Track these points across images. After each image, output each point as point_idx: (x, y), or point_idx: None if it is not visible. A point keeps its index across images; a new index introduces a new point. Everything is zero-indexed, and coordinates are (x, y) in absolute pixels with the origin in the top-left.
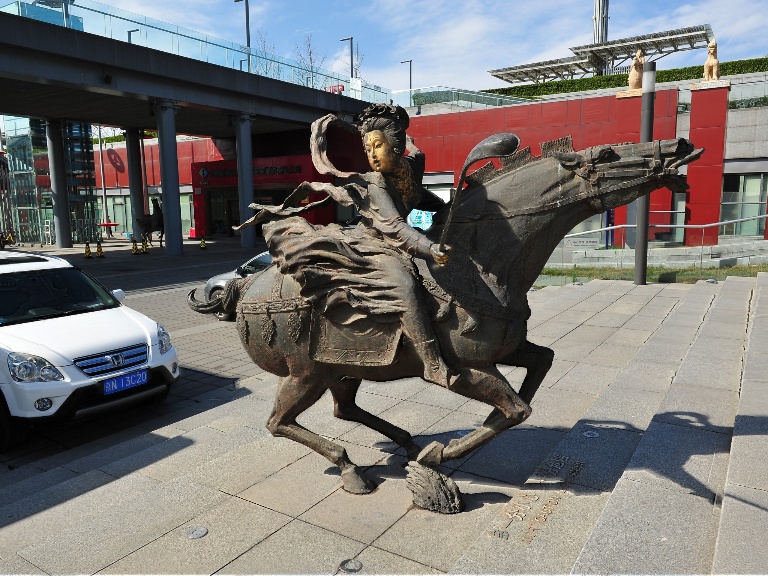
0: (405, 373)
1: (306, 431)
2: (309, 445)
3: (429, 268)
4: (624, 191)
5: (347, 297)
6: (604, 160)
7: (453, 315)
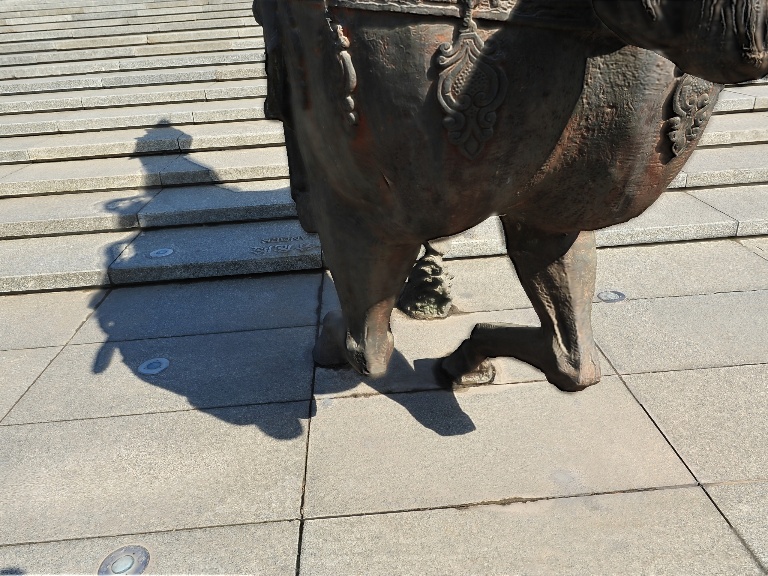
0: None
1: None
2: None
3: None
4: None
5: None
6: None
7: None
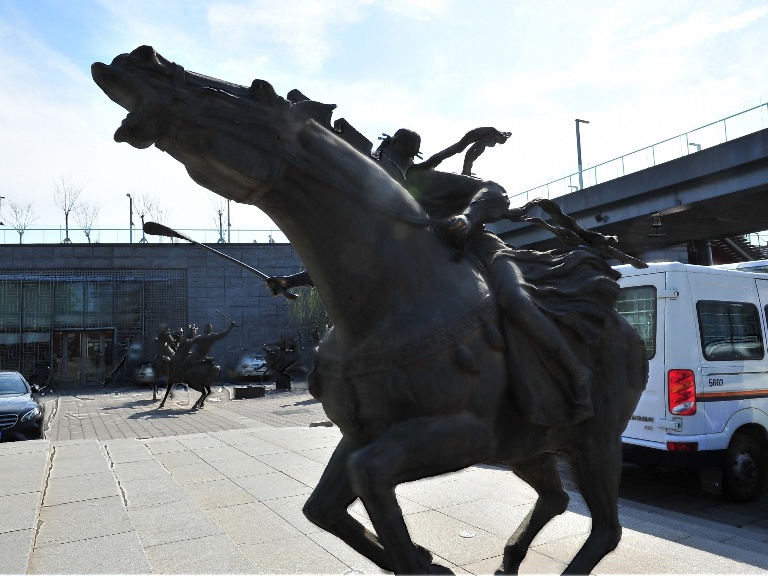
0: None
1: None
2: None
3: None
4: None
5: None
6: None
7: None
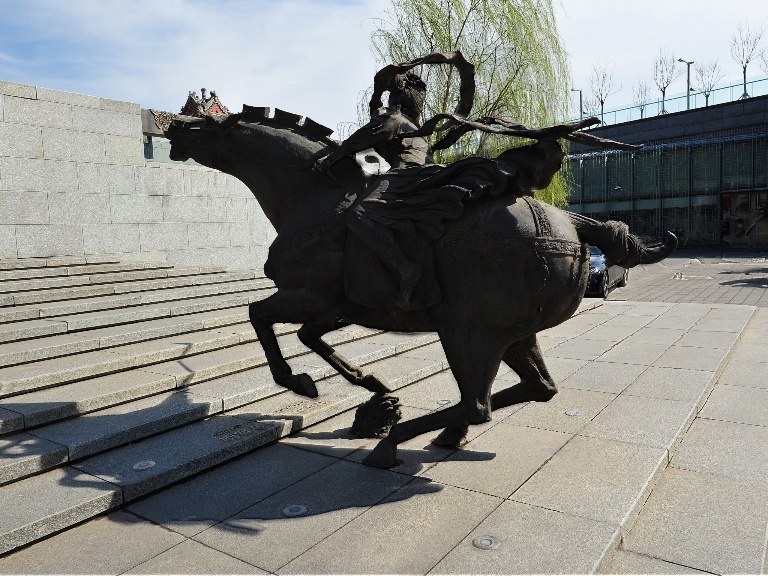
0: None
1: None
2: None
3: None
4: None
5: None
6: None
7: None
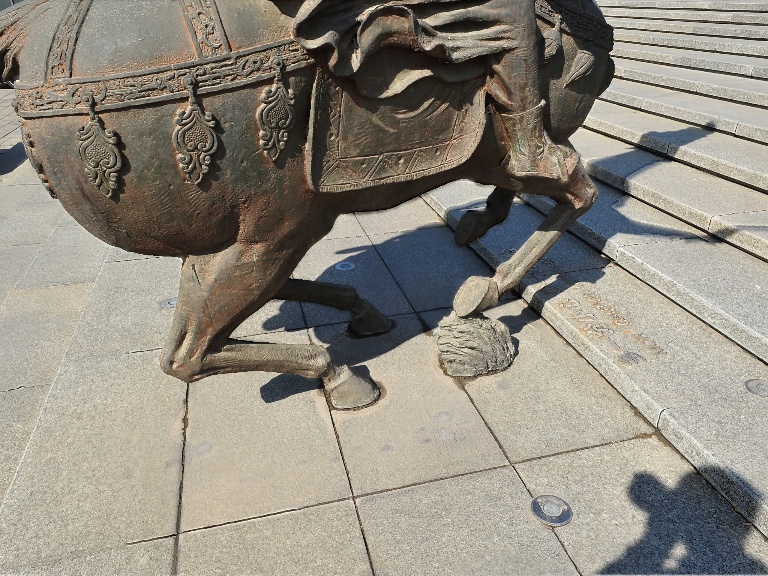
0: (453, 178)
1: (257, 345)
2: (269, 367)
3: None
4: None
5: (414, 27)
6: None
7: None
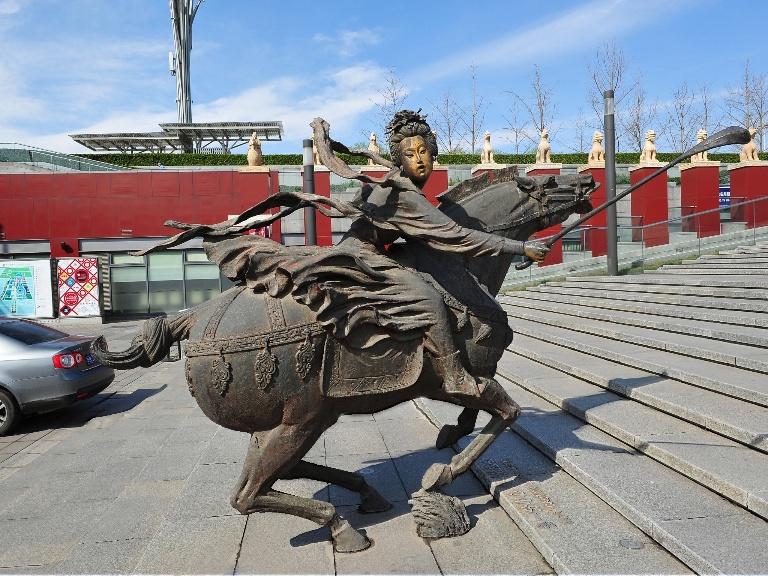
0: (413, 395)
1: (289, 495)
2: (294, 511)
3: (437, 281)
4: (562, 212)
5: (376, 315)
6: (550, 186)
7: (468, 324)
